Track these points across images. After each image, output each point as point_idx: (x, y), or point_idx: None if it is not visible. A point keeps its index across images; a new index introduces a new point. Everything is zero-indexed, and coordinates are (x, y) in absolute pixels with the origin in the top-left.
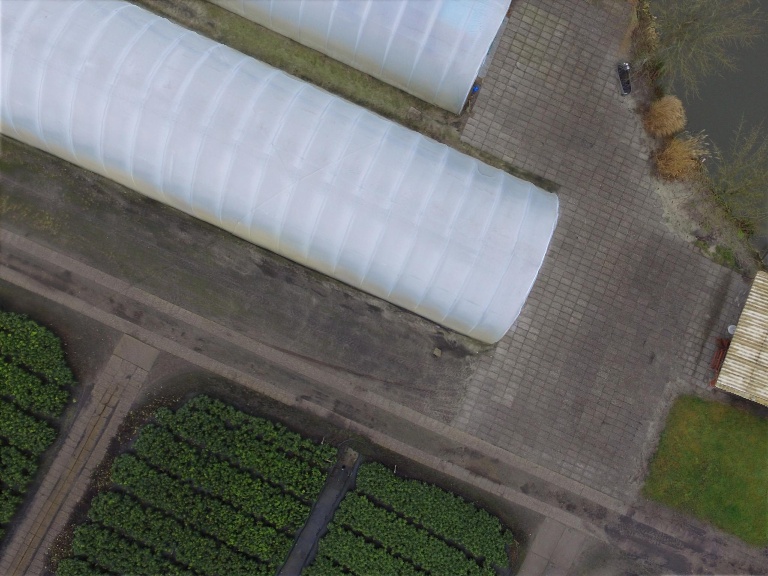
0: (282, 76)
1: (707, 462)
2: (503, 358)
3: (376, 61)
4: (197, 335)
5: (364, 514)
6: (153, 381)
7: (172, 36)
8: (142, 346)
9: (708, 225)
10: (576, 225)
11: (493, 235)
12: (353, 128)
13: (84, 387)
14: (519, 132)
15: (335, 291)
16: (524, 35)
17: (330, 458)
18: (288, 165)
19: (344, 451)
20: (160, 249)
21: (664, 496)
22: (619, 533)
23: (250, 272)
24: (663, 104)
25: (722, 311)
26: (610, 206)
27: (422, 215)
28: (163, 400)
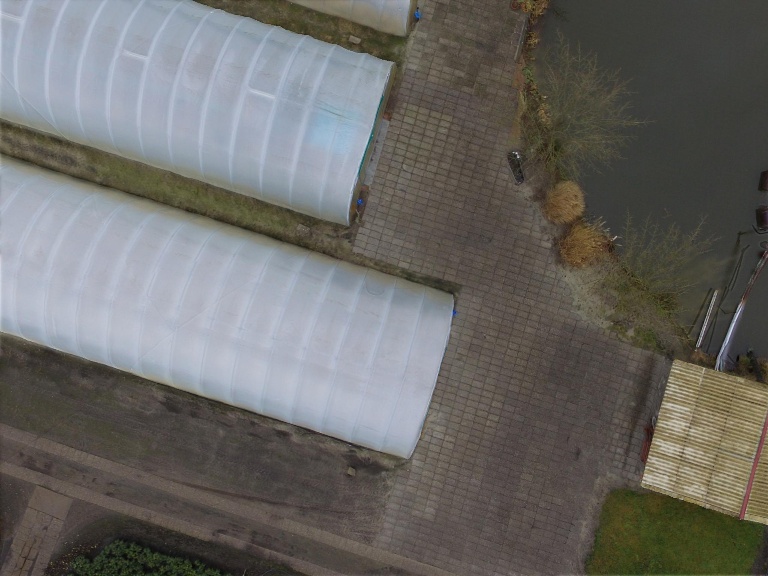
0: (158, 218)
1: (649, 559)
2: (420, 470)
3: (254, 187)
4: (108, 479)
5: None
6: (69, 530)
7: (44, 195)
8: (55, 496)
9: (623, 308)
10: (482, 324)
11: (381, 361)
12: (230, 265)
13: (3, 542)
14: (413, 236)
15: (241, 420)
16: (407, 136)
17: None
18: (165, 315)
19: None
20: (64, 397)
21: None
22: None
23: (154, 410)
24: (556, 193)
25: (648, 397)
26: (516, 300)
27: (306, 349)
28: (81, 548)
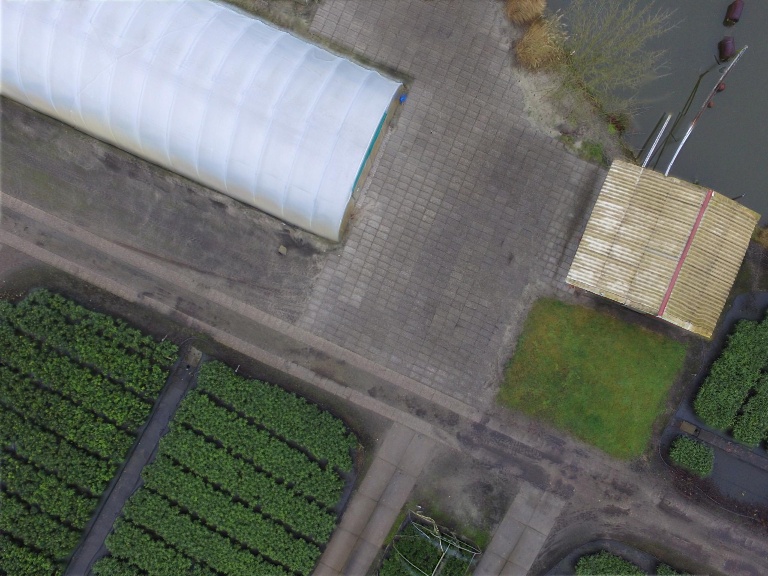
0: None
1: (568, 369)
2: (351, 257)
3: None
4: (39, 230)
5: (204, 413)
6: None
7: None
8: None
9: (574, 120)
10: (430, 119)
11: (318, 115)
12: (179, 9)
13: None
14: (371, 23)
15: (178, 187)
16: None
17: (171, 355)
18: (106, 44)
19: (187, 350)
20: (4, 144)
21: (520, 403)
22: (472, 441)
23: (93, 167)
24: None
25: (587, 210)
26: (467, 100)
27: (244, 95)
28: (6, 295)
